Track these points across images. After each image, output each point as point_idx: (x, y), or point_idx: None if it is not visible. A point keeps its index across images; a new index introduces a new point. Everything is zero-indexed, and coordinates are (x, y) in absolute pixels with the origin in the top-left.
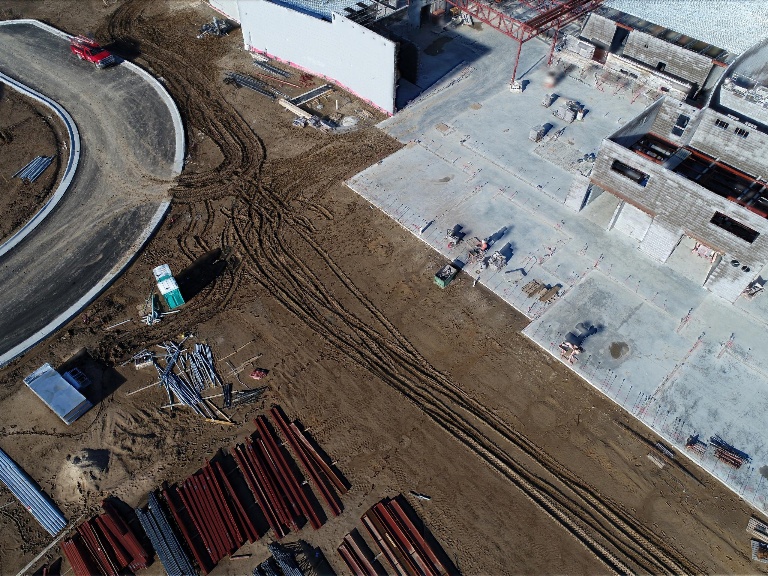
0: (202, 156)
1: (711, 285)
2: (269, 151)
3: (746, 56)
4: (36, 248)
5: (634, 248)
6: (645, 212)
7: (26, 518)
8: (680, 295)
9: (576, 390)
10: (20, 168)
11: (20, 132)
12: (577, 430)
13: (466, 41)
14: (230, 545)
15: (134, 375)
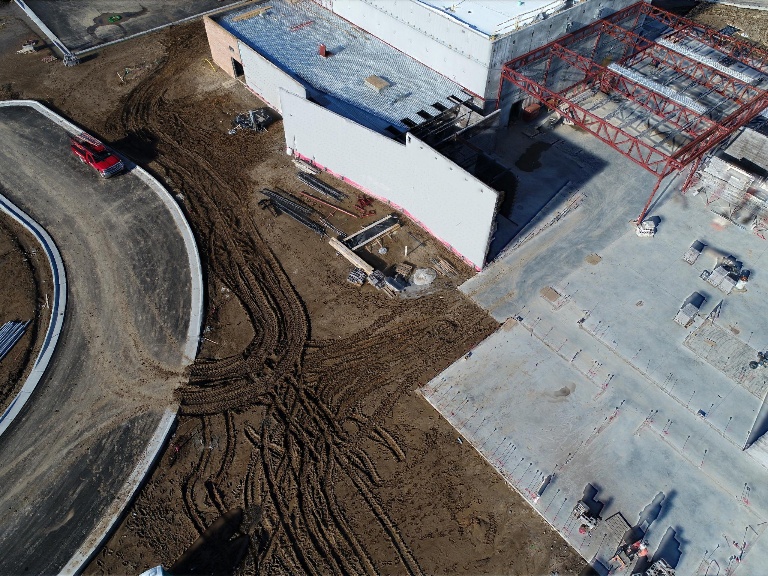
0: (225, 329)
1: None
2: (315, 324)
3: None
4: None
5: None
6: None
7: None
8: None
9: None
10: None
11: None
12: None
13: (569, 150)
14: None
15: None
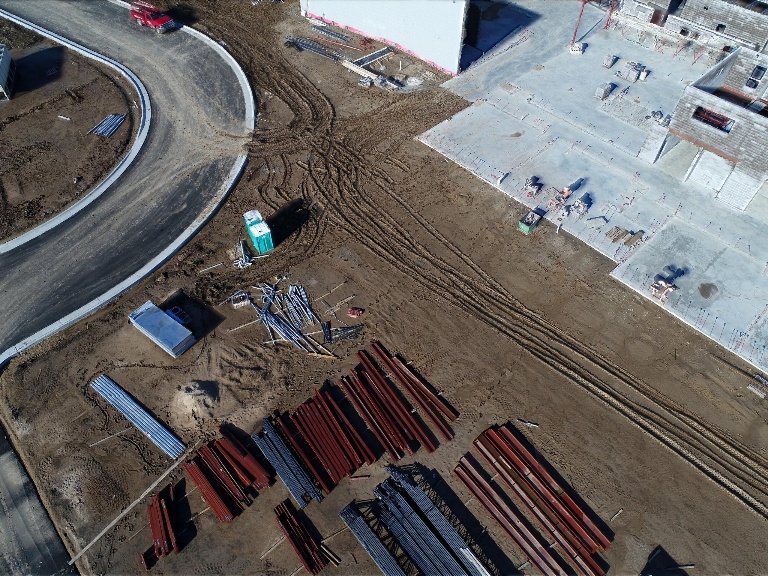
0: (272, 114)
1: None
2: (338, 109)
3: None
4: (120, 198)
5: (711, 197)
6: (727, 159)
7: (145, 442)
8: (762, 240)
9: (670, 327)
10: (94, 125)
11: (89, 92)
12: (675, 364)
13: (520, 7)
14: (349, 466)
15: (233, 313)
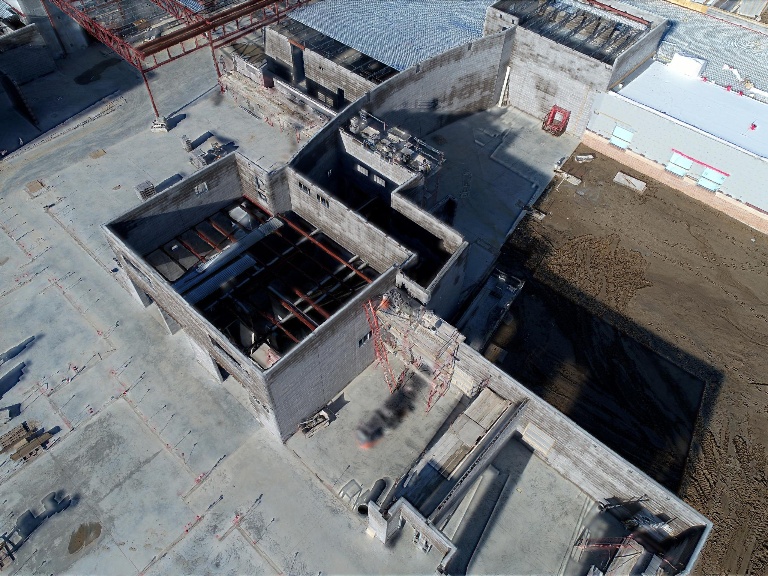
0: None
1: (259, 418)
2: None
3: (398, 85)
4: None
5: (193, 360)
6: None
7: None
8: (219, 434)
9: None
10: None
11: None
12: None
13: None
14: None
15: None
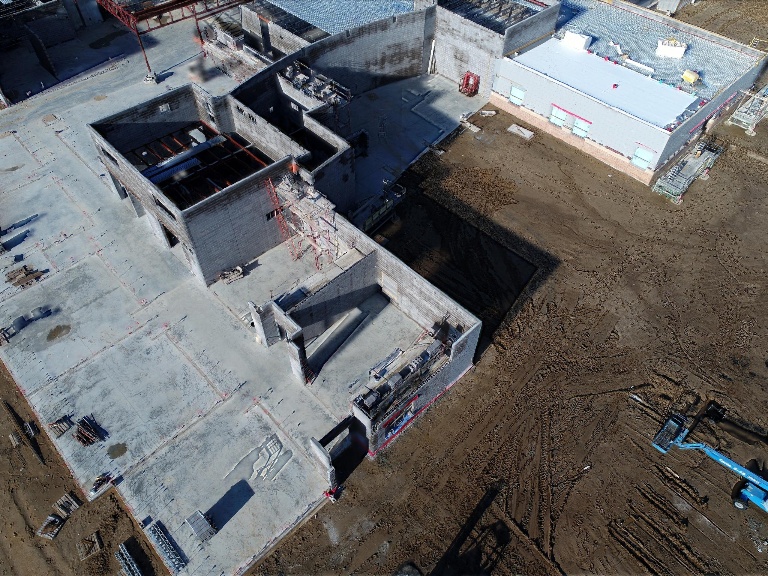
0: None
1: (192, 269)
2: None
3: (330, 45)
4: None
5: (151, 234)
6: None
7: None
8: (162, 279)
9: None
10: None
11: None
12: None
13: None
14: None
15: None
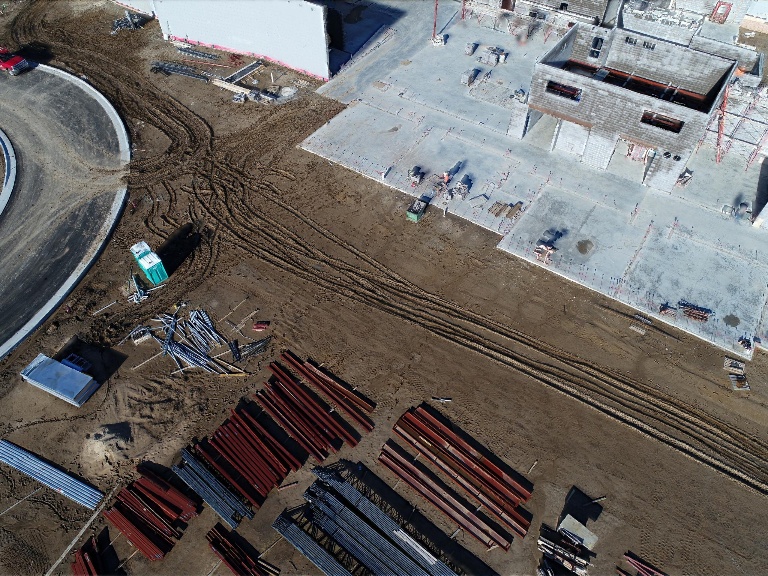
0: (147, 142)
1: (649, 181)
2: (215, 129)
3: None
4: None
5: (577, 162)
6: (582, 125)
7: (59, 500)
8: (625, 194)
9: (556, 286)
10: None
11: None
12: (566, 318)
13: (381, 7)
14: (275, 477)
15: (135, 350)
